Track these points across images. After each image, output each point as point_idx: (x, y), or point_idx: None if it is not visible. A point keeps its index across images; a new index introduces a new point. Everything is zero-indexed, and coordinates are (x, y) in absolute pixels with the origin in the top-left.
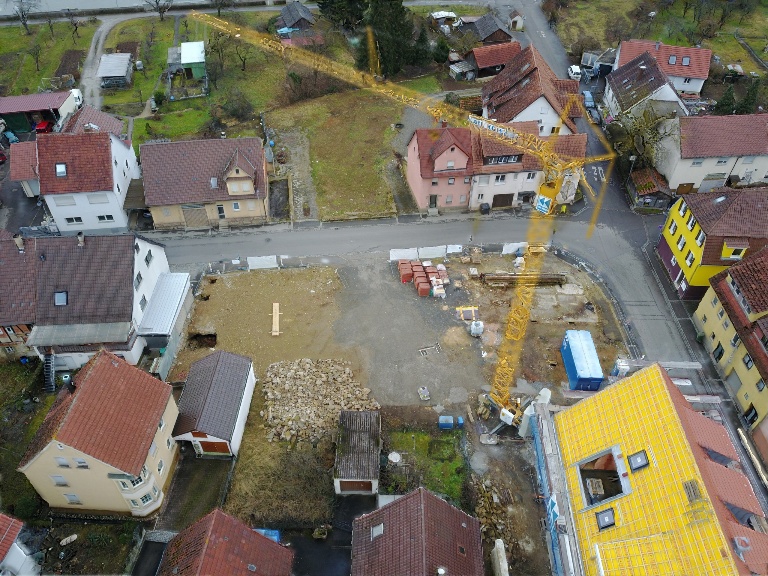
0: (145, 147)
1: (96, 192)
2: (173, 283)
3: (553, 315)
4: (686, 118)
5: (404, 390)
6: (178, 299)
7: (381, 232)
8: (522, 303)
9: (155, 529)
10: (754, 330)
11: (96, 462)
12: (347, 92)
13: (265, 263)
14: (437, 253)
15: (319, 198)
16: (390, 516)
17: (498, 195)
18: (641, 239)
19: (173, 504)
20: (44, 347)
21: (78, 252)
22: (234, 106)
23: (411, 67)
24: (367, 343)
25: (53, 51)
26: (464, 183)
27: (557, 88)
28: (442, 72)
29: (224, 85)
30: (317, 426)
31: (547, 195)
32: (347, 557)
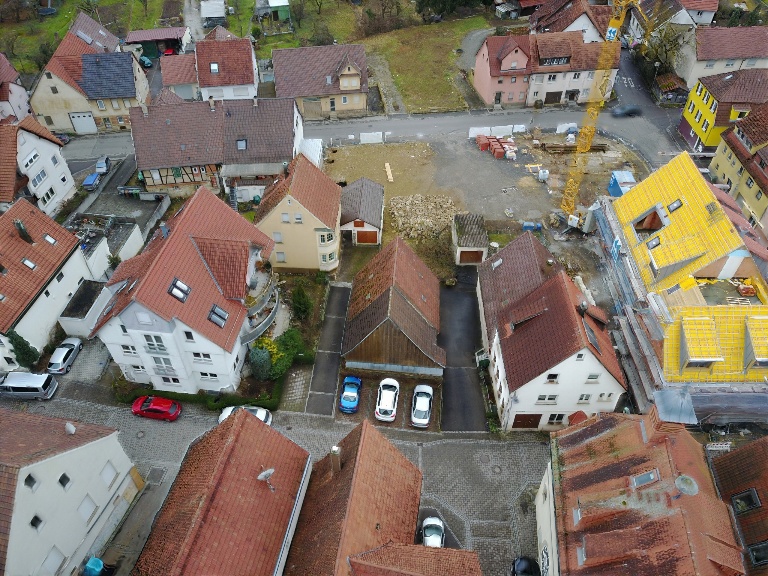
0: (276, 52)
1: (241, 85)
2: (312, 145)
3: (600, 169)
4: (701, 29)
5: (494, 212)
6: (318, 154)
7: (458, 121)
8: (575, 162)
9: (336, 281)
10: (754, 159)
11: (310, 216)
12: (412, 28)
13: (373, 139)
14: (505, 132)
15: (404, 99)
16: (506, 253)
17: (550, 93)
18: (665, 123)
19: (344, 269)
20: (230, 181)
21: (253, 111)
22: (321, 37)
23: (461, 10)
24: (461, 186)
25: (154, 2)
26: (523, 82)
27: (594, 12)
28: (489, 13)
29: (305, 25)
30: (435, 229)
31: (614, 27)
32: (470, 296)
